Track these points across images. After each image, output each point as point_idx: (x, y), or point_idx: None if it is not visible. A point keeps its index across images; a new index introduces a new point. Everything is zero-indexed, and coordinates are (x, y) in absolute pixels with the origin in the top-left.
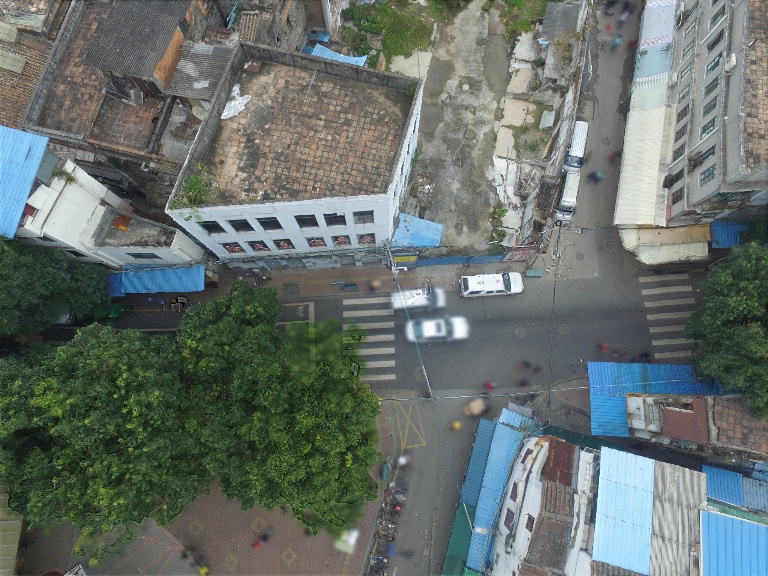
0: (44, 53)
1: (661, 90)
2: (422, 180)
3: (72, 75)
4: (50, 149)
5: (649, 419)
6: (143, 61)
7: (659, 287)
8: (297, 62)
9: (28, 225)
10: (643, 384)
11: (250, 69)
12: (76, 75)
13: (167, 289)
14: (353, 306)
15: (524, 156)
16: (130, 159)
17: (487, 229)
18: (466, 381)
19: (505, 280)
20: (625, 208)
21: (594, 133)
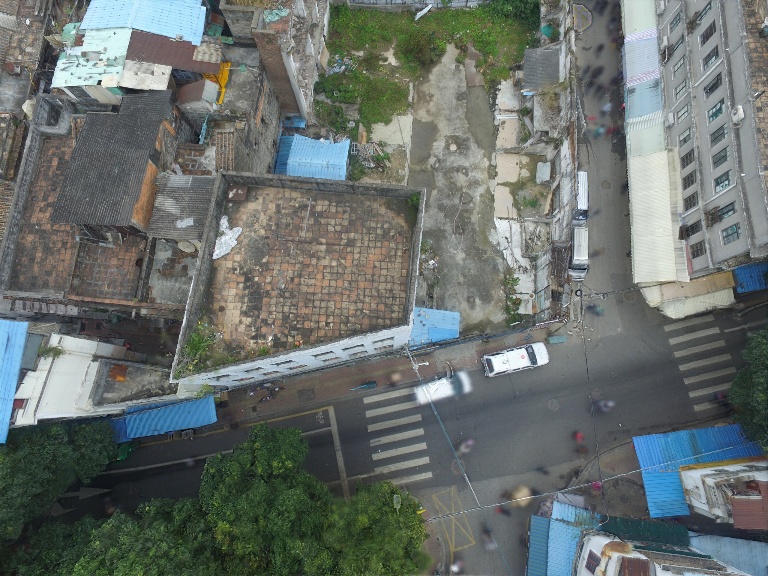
0: (3, 195)
1: (657, 130)
2: (425, 255)
3: (39, 222)
4: (30, 323)
5: (712, 501)
6: (118, 208)
7: (686, 334)
8: (286, 184)
9: (19, 420)
10: (694, 454)
11: (236, 198)
12: (44, 222)
13: (177, 427)
14: (375, 403)
15: (526, 214)
16: (118, 308)
17: (500, 298)
18: (506, 467)
19: (529, 353)
20: (643, 264)
21: (592, 178)
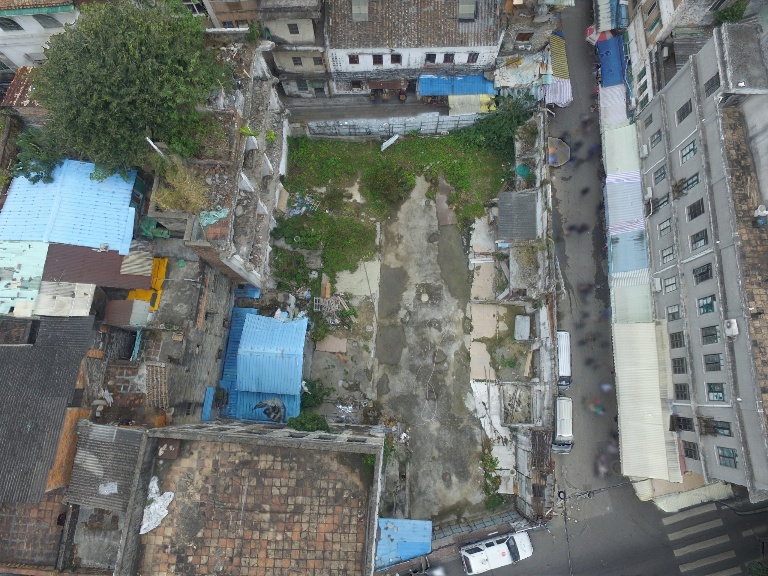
0: None
1: (643, 291)
2: (396, 427)
3: None
4: None
5: None
6: (28, 479)
7: (680, 512)
8: None
9: None
10: None
11: (166, 456)
12: None
13: None
14: None
15: (504, 375)
16: None
17: (479, 475)
18: None
19: (511, 546)
20: (632, 454)
21: (575, 329)
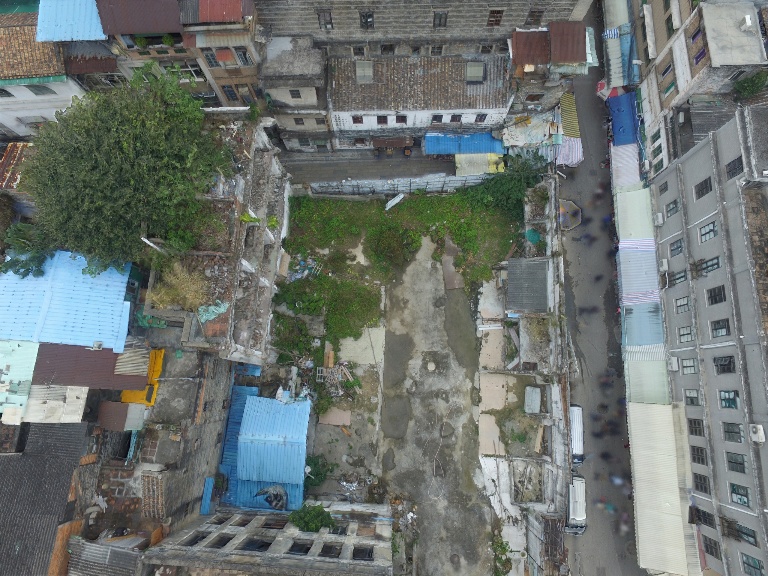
0: None
1: (659, 368)
2: (402, 506)
3: None
4: None
5: None
6: None
7: None
8: None
9: None
10: None
11: None
12: None
13: None
14: None
15: (514, 450)
16: None
17: (488, 557)
18: None
19: None
20: (649, 545)
21: (587, 400)
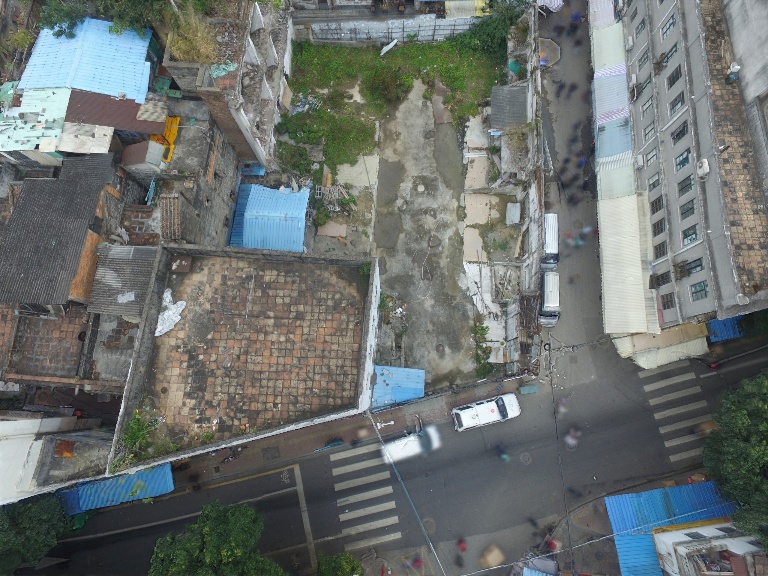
0: None
1: (627, 171)
2: (392, 303)
3: None
4: None
5: (684, 572)
6: (54, 284)
7: (661, 380)
8: (231, 255)
9: None
10: (667, 515)
11: (179, 270)
12: None
13: (132, 497)
14: (342, 461)
15: (495, 257)
16: (61, 385)
17: (470, 346)
18: (477, 525)
19: (500, 406)
20: (613, 314)
21: (564, 217)
